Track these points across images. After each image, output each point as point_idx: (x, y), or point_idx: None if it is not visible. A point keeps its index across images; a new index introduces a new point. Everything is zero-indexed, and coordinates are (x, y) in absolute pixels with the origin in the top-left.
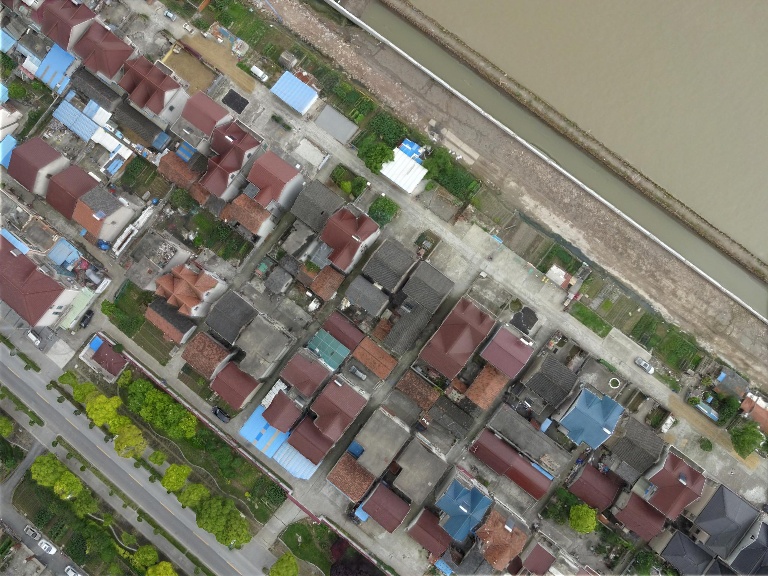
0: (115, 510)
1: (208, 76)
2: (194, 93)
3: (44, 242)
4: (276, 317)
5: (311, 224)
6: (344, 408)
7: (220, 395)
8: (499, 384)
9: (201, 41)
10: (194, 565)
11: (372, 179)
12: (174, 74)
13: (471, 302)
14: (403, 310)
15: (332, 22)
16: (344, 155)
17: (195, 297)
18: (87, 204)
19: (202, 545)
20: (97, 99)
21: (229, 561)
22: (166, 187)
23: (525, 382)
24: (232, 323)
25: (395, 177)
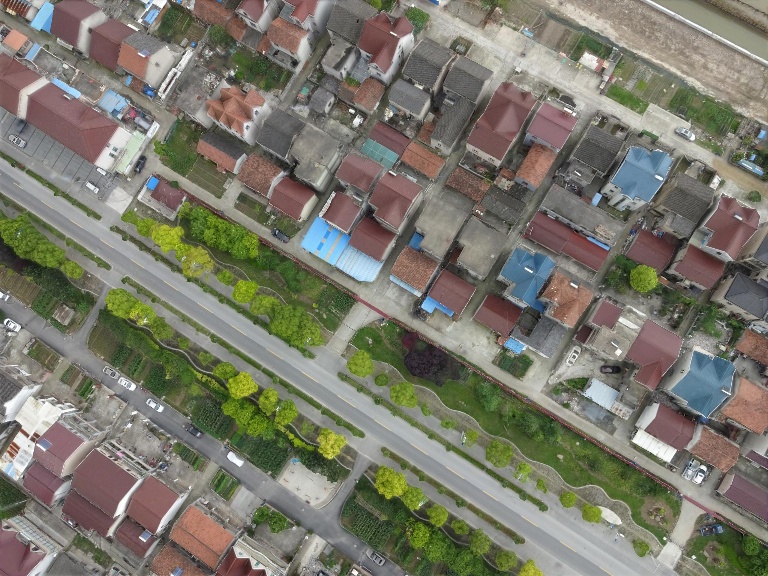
0: (189, 339)
1: None
2: None
3: (92, 94)
4: None
5: (348, 35)
6: (402, 193)
7: (277, 218)
8: (547, 161)
9: None
10: (271, 379)
11: None
12: None
13: (512, 82)
14: (446, 105)
15: None
16: None
17: (245, 117)
18: (131, 45)
19: (276, 360)
20: None
21: (304, 371)
22: (202, 32)
23: (573, 153)
24: (283, 135)
25: None
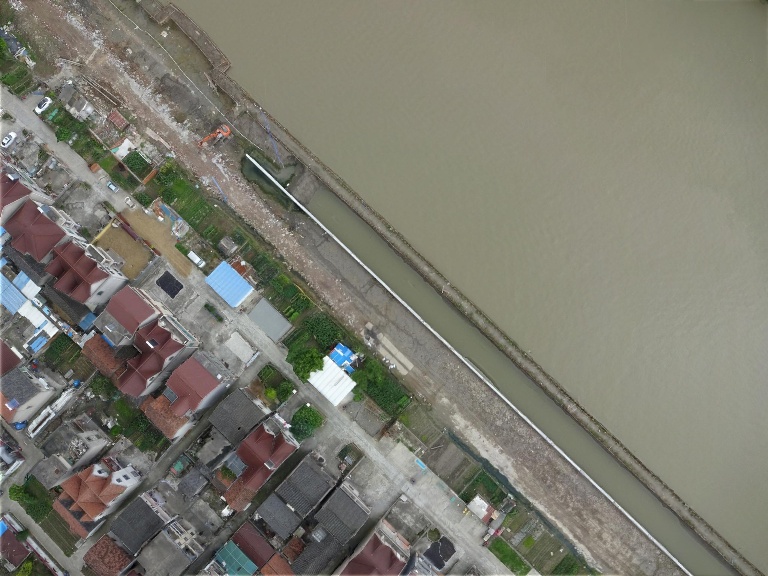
0: None
1: (145, 255)
2: (129, 271)
3: None
4: (188, 518)
5: (228, 436)
6: None
7: None
8: None
9: (142, 216)
10: None
11: (300, 382)
12: (107, 256)
13: (381, 543)
14: None
15: (279, 206)
16: (274, 354)
17: (101, 502)
18: (1, 390)
19: None
20: (27, 272)
21: None
22: (90, 367)
23: None
24: (135, 535)
25: (322, 387)
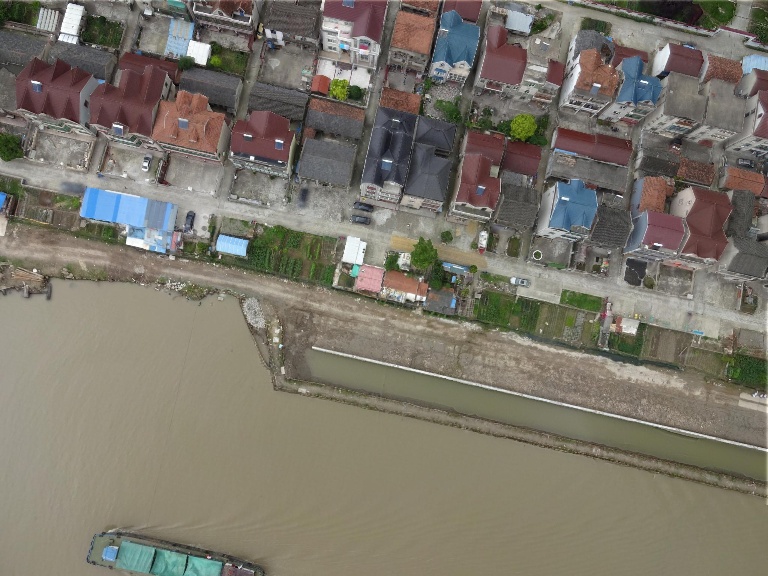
0: None
1: None
2: None
3: None
4: None
5: None
6: None
7: None
8: (647, 203)
9: None
10: None
11: None
12: None
13: None
14: None
15: None
16: None
17: None
18: None
19: None
20: None
21: None
22: None
23: None
24: None
25: None
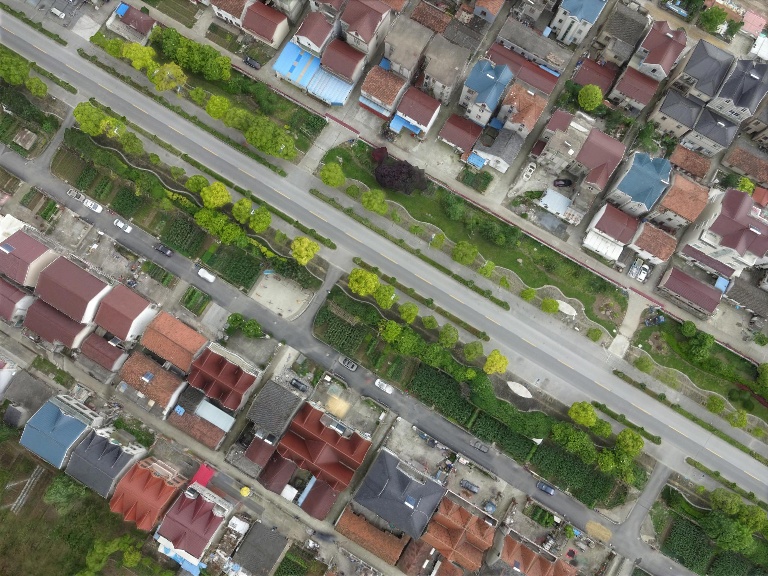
0: None
1: None
2: None
3: None
4: None
5: None
6: (372, 7)
7: (248, 47)
8: None
9: None
10: (243, 197)
11: None
12: None
13: None
14: None
15: None
16: None
17: None
18: None
19: (248, 179)
20: None
21: (276, 189)
22: None
23: None
24: None
25: None
